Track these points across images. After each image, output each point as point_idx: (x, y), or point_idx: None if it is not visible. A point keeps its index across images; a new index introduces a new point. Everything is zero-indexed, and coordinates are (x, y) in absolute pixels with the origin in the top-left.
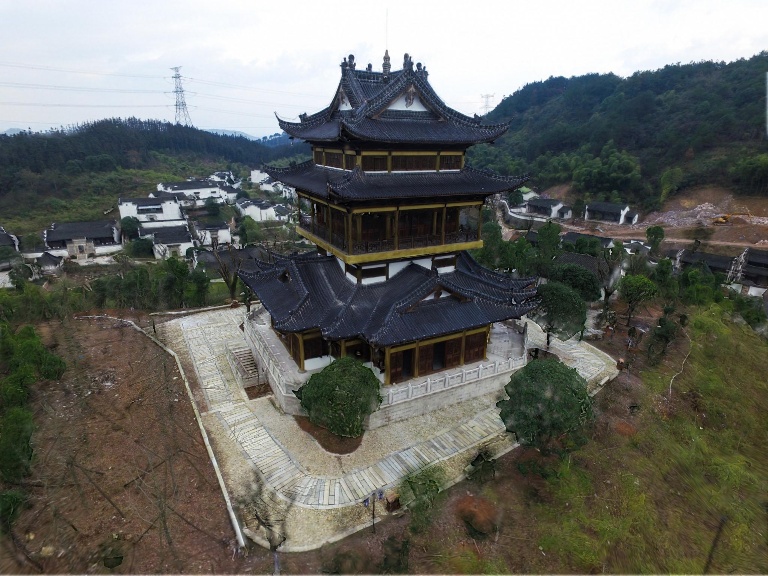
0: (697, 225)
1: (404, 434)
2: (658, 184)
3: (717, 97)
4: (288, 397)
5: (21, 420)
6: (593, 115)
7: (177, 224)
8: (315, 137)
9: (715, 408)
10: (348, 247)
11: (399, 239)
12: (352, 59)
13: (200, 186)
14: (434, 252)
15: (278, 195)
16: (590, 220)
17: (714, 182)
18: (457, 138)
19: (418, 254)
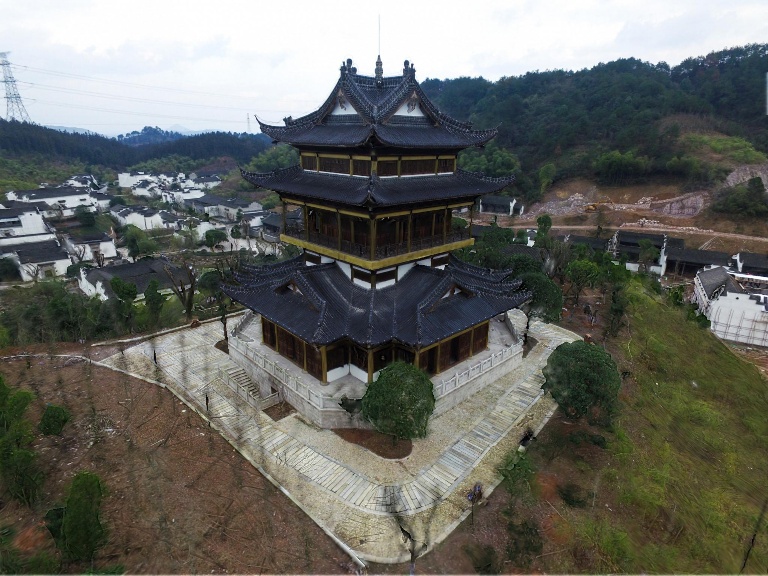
0: (573, 213)
1: (447, 429)
2: (537, 178)
3: (572, 102)
4: (326, 411)
5: (90, 484)
6: (471, 116)
7: (43, 239)
8: (318, 142)
9: (659, 366)
10: (369, 253)
11: (411, 242)
12: (350, 63)
13: (65, 193)
14: (438, 252)
15: (157, 200)
16: (484, 213)
17: (581, 175)
18: (456, 143)
19: (426, 255)
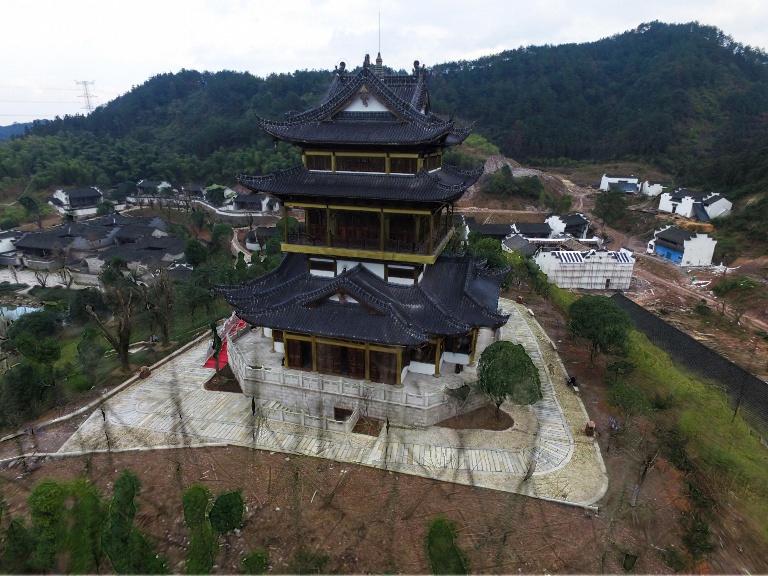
0: None
1: None
2: None
3: None
4: (432, 409)
5: None
6: (248, 112)
7: None
8: (357, 140)
9: None
10: (426, 248)
11: None
12: None
13: None
14: None
15: None
16: None
17: None
18: None
19: None
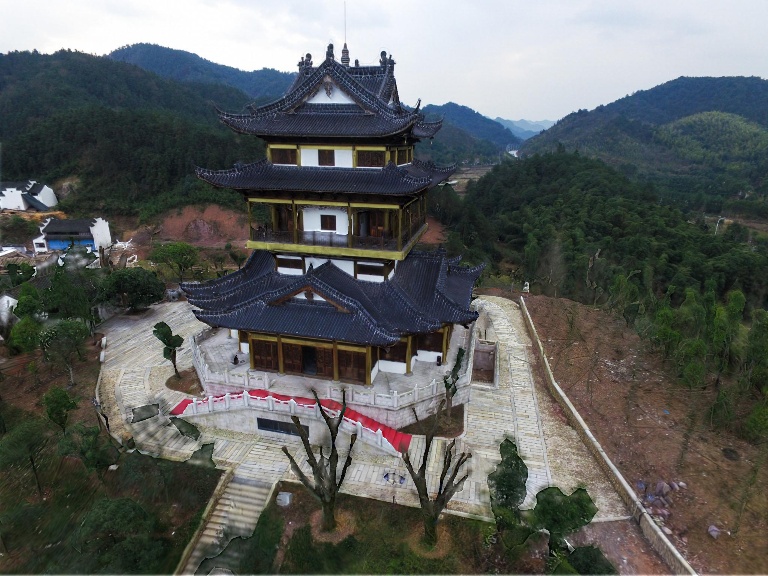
0: None
1: None
2: None
3: None
4: None
5: None
6: None
7: None
8: None
9: None
10: None
11: None
12: (384, 56)
13: None
14: None
15: None
16: None
17: None
18: None
19: None
